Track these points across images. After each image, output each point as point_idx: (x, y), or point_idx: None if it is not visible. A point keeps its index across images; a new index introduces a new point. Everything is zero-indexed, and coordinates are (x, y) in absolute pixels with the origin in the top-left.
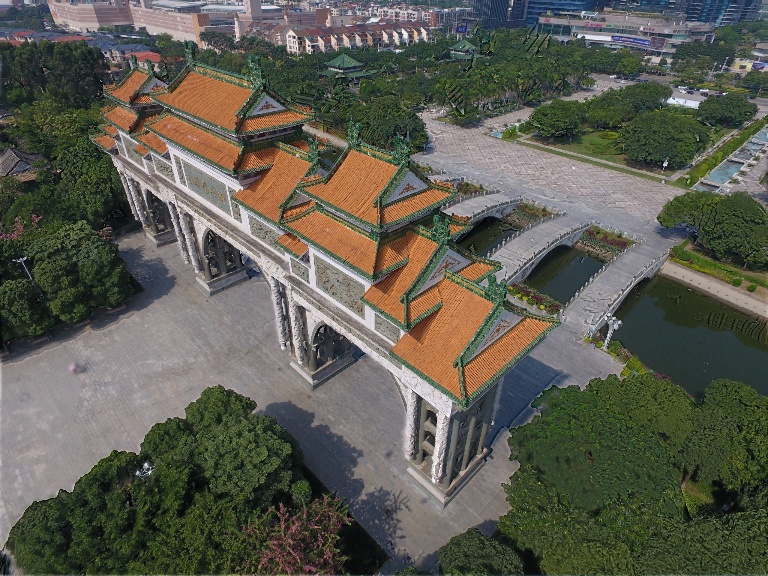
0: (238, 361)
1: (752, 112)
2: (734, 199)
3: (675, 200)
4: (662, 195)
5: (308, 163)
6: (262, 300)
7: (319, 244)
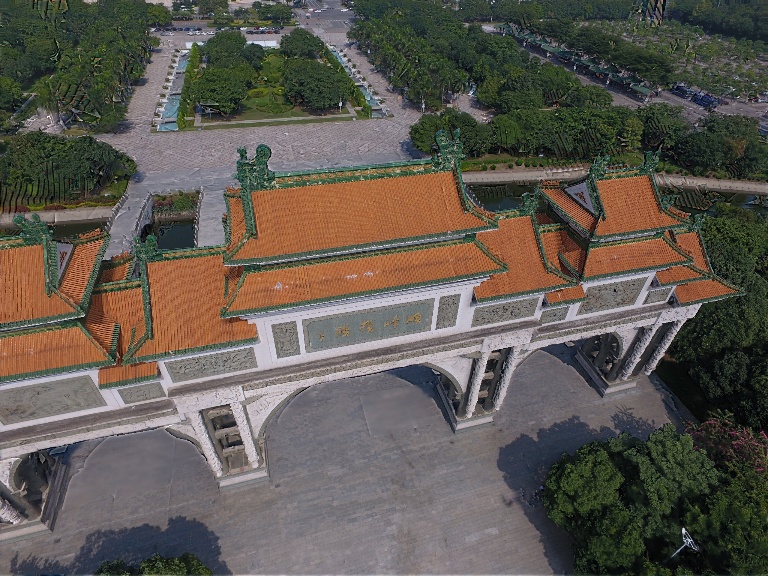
0: (420, 478)
1: (321, 42)
2: (456, 114)
3: (419, 129)
4: (369, 129)
5: (519, 218)
6: (320, 424)
7: (624, 270)
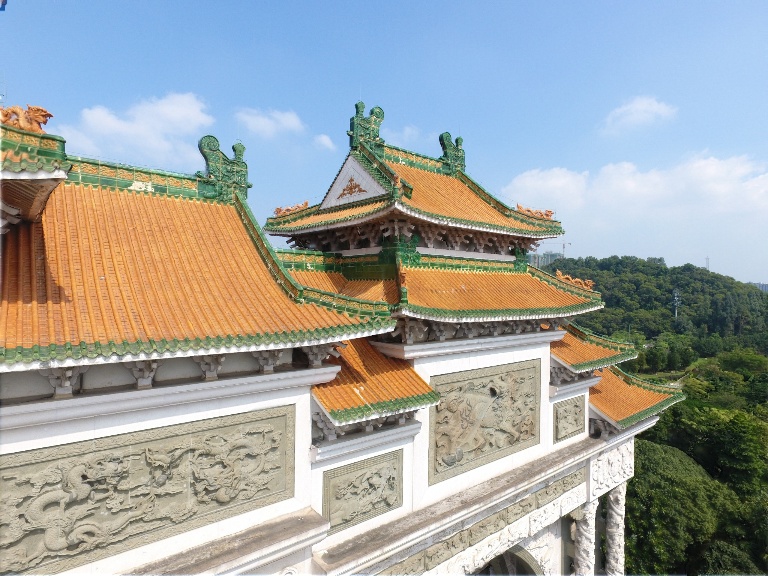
0: None
1: None
2: None
3: None
4: None
5: (202, 202)
6: None
7: (495, 309)
